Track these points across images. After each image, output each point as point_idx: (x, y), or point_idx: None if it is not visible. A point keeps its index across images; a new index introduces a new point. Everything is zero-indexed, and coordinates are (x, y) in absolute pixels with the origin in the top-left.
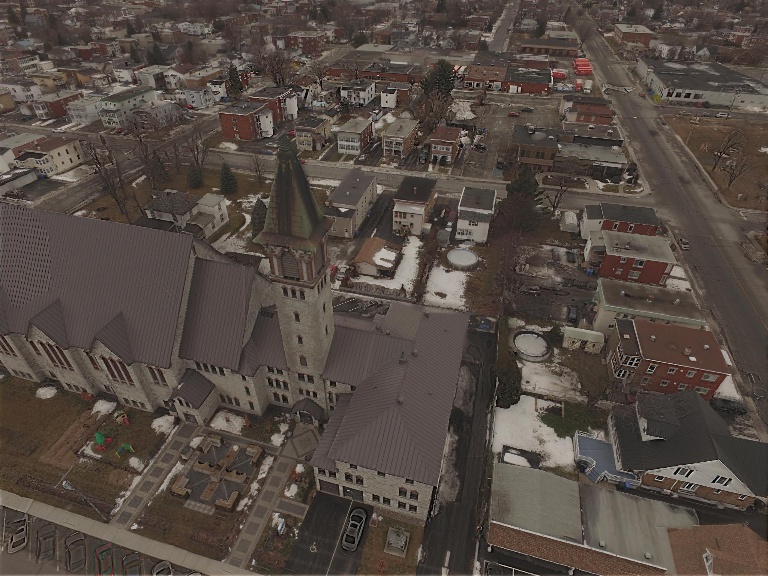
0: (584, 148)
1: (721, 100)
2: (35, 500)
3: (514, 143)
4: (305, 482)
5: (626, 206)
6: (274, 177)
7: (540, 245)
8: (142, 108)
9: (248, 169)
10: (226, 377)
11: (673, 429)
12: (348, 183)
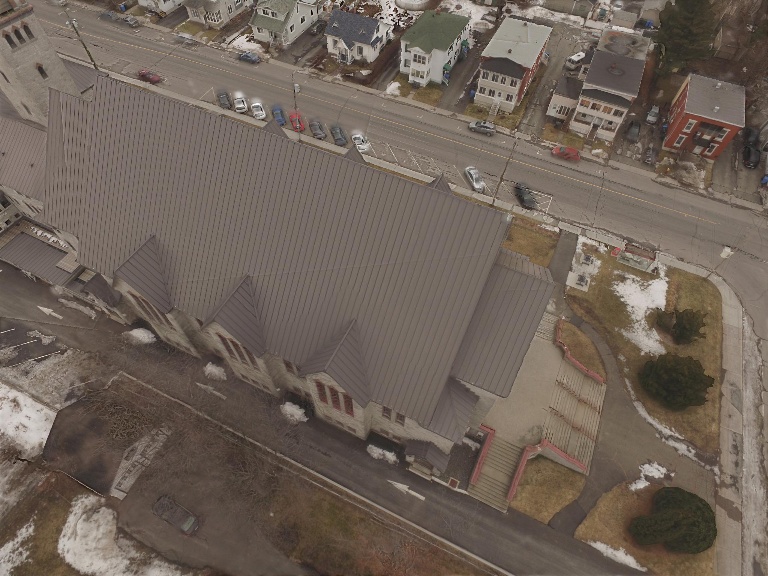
0: None
1: None
2: None
3: None
4: None
5: None
6: None
7: None
8: None
9: None
10: None
11: None
12: None
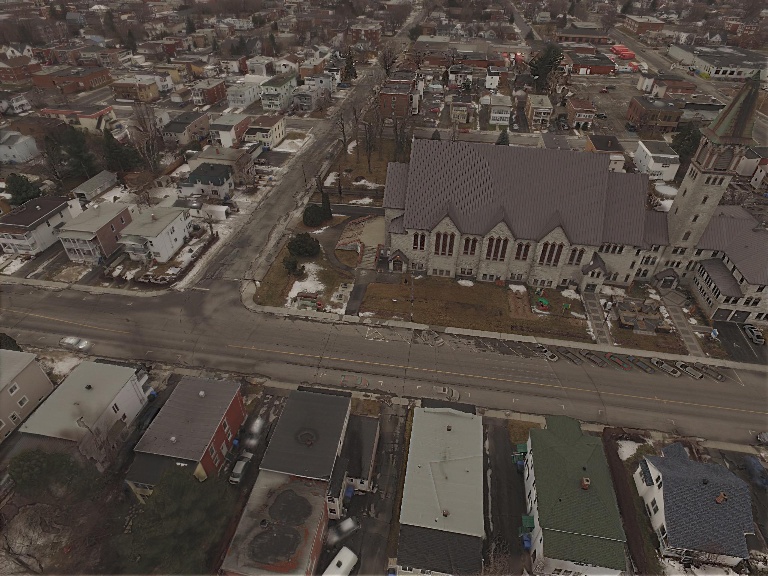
0: (696, 112)
1: None
2: (535, 337)
3: (647, 109)
4: (697, 316)
5: None
6: (742, 98)
7: None
8: (302, 91)
9: (428, 138)
10: (621, 255)
11: None
12: (549, 141)
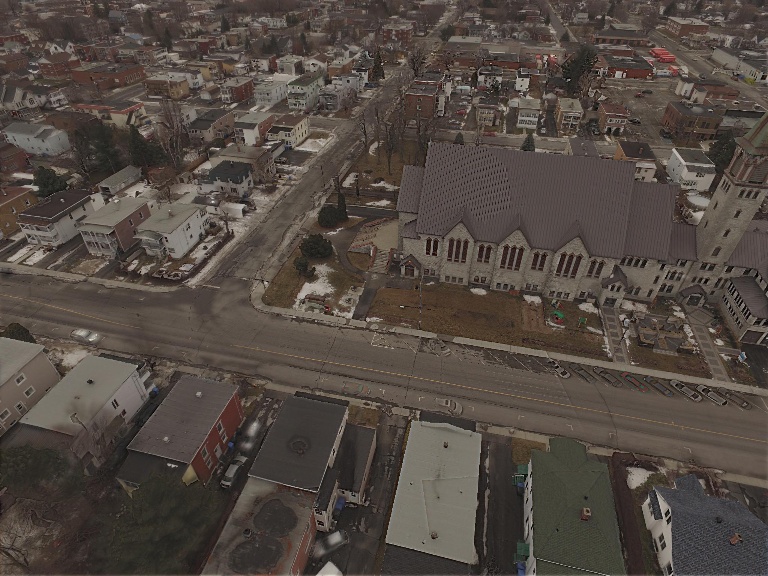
0: (737, 119)
1: None
2: (547, 351)
3: (684, 115)
4: (724, 337)
5: None
6: None
7: None
8: (328, 91)
9: (452, 141)
10: (644, 269)
11: None
12: (576, 147)
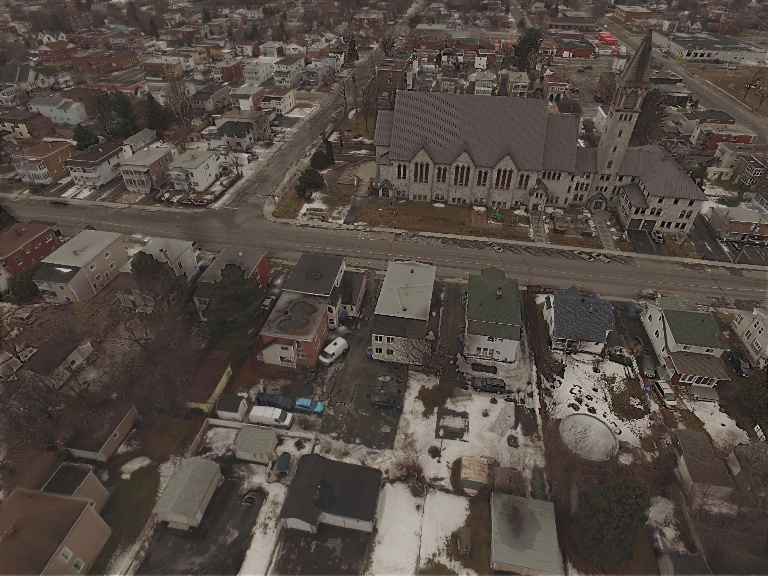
0: None
1: (727, 57)
2: None
3: (612, 82)
4: (617, 227)
5: (713, 110)
6: (640, 51)
7: (660, 138)
8: (309, 69)
9: None
10: (560, 181)
11: None
12: None
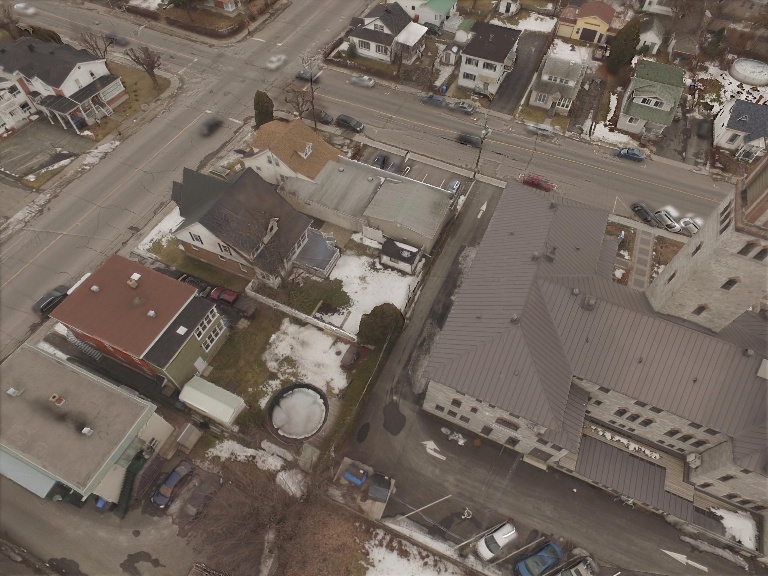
0: None
1: None
2: None
3: None
4: None
5: None
6: None
7: None
8: None
9: None
10: None
11: (252, 210)
12: None
